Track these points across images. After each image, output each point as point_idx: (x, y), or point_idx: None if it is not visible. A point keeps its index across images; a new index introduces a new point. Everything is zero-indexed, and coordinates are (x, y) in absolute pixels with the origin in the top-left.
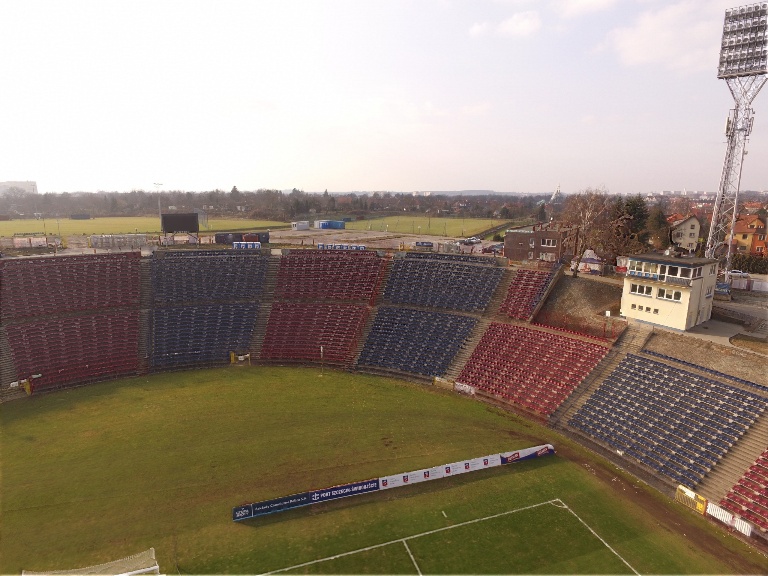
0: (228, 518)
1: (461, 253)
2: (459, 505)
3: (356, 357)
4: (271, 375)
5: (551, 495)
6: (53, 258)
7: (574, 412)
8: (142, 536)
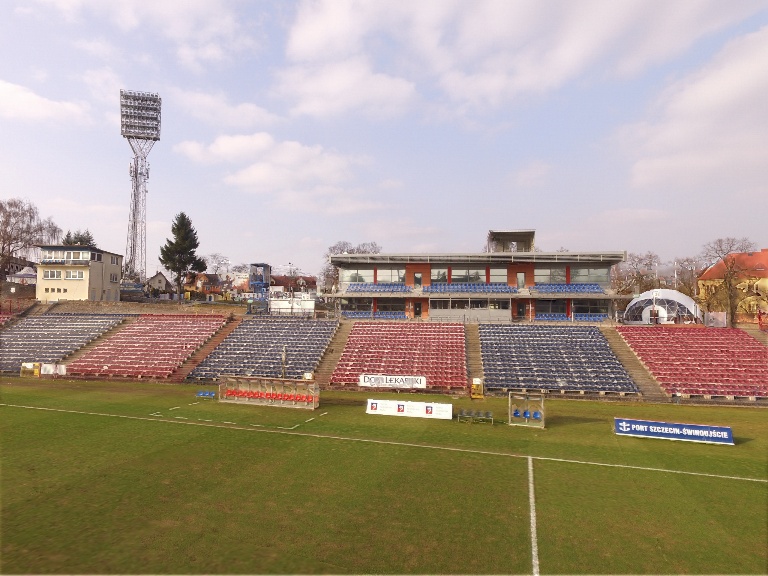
0: None
1: None
2: None
3: None
4: None
5: None
6: None
7: None
8: None
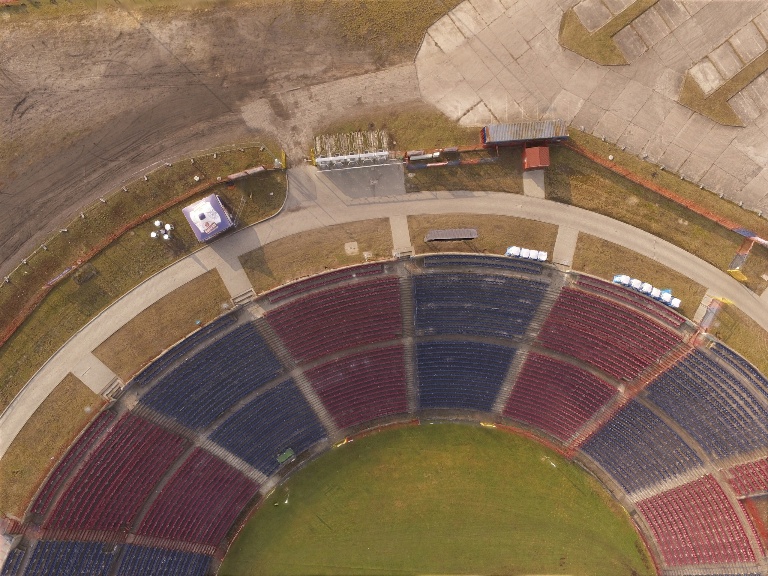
0: None
1: None
2: None
3: (579, 440)
4: (508, 448)
5: None
6: (308, 279)
7: (682, 574)
8: None
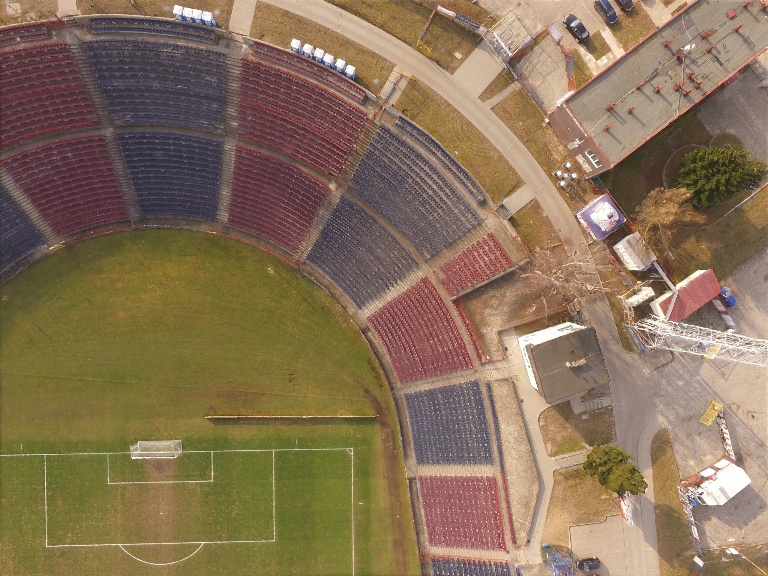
0: (203, 416)
1: (511, 59)
2: (306, 438)
3: (306, 251)
4: (235, 259)
5: (351, 445)
6: None
7: (413, 390)
8: (169, 416)
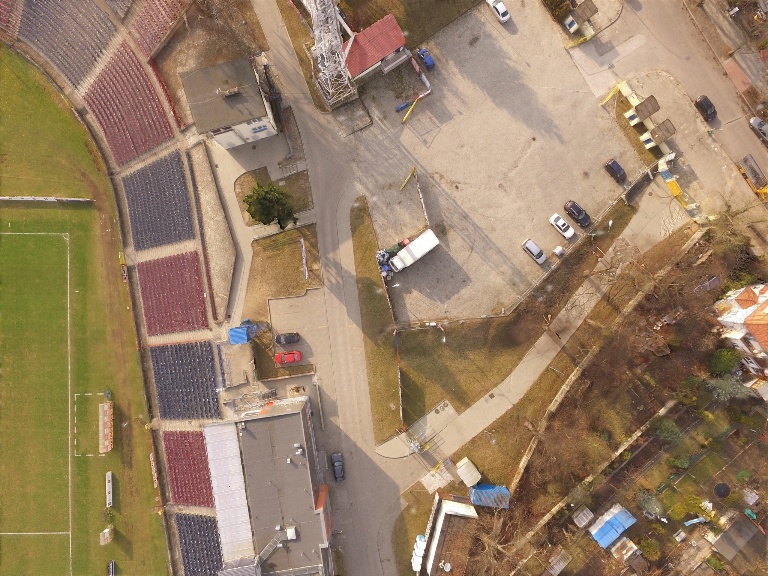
0: None
1: None
2: (19, 222)
3: (17, 25)
4: None
5: (66, 230)
6: None
7: (129, 172)
8: None
